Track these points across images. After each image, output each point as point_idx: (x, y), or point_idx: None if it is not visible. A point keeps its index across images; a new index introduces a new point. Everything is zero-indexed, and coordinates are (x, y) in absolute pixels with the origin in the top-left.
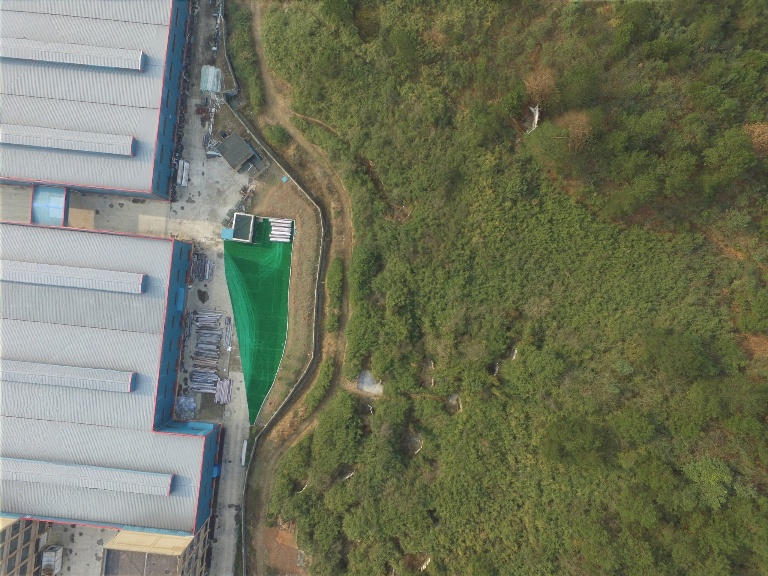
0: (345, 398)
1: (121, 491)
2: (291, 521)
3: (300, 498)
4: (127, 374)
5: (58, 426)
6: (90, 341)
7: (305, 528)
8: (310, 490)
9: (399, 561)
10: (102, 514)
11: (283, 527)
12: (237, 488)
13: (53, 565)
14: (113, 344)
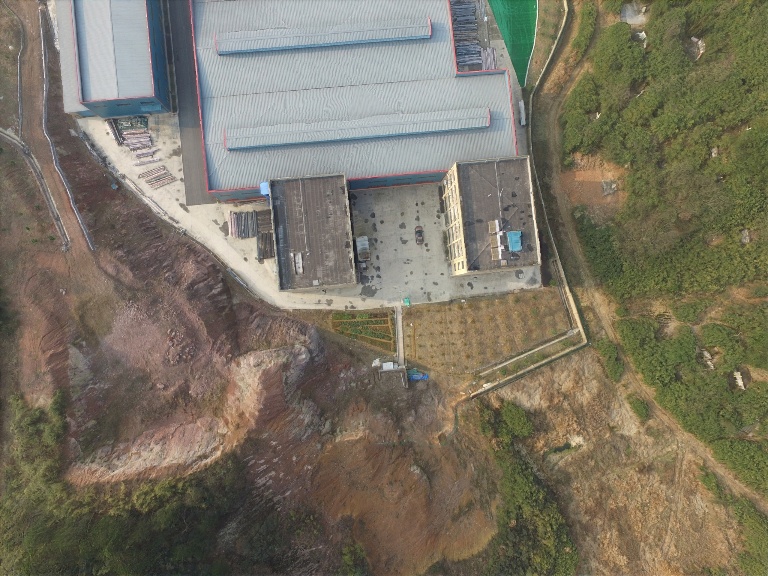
0: (619, 24)
1: (442, 131)
2: (590, 154)
3: (603, 118)
4: (425, 18)
5: (362, 89)
6: (375, 2)
7: (618, 139)
8: (609, 111)
9: (721, 137)
10: (423, 164)
11: (582, 164)
12: (521, 149)
13: (368, 248)
14: (398, 1)
